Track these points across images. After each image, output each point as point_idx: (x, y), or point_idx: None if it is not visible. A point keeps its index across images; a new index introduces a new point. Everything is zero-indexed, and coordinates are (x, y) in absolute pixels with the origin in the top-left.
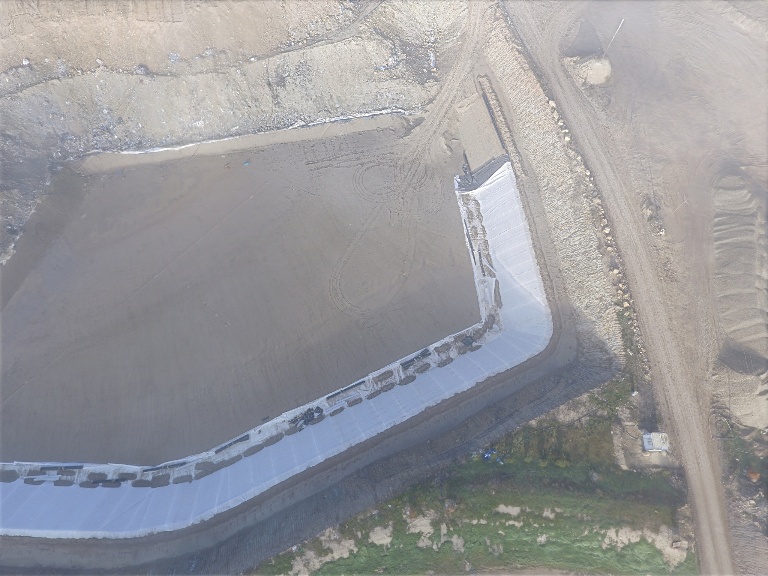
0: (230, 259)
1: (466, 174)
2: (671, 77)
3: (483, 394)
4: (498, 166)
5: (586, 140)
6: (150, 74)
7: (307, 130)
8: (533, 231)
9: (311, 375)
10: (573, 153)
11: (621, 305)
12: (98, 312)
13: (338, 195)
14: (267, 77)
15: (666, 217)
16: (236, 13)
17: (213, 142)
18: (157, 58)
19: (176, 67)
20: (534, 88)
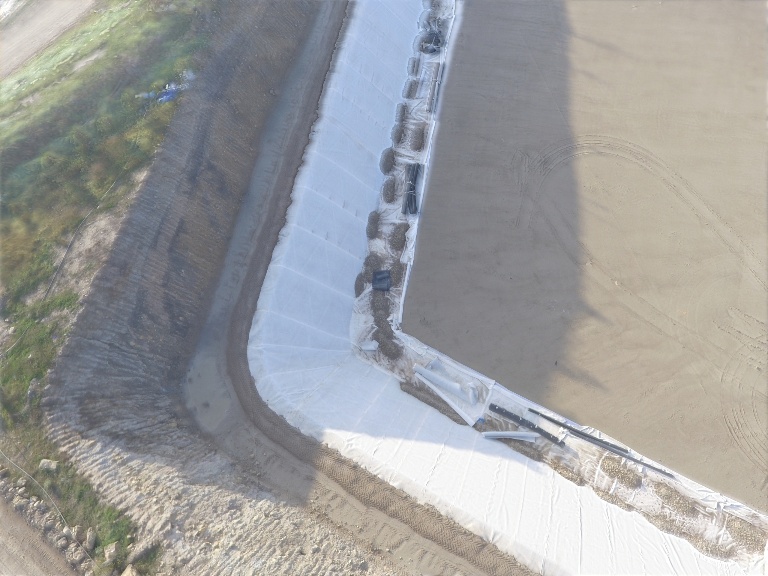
0: (766, 44)
1: None
2: None
3: (268, 198)
4: None
5: None
6: None
7: None
8: None
9: (486, 61)
10: None
11: (141, 561)
12: None
13: None
14: None
15: None
16: None
17: None
18: None
19: None
20: None
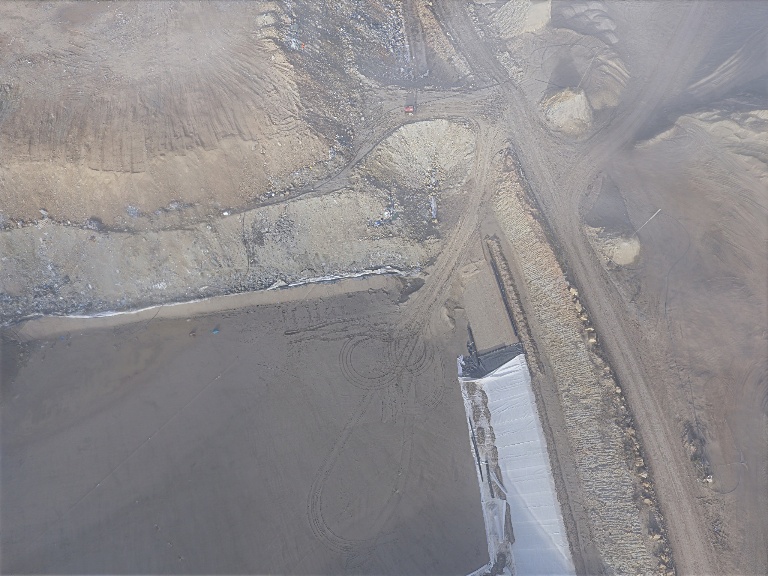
0: (190, 463)
1: (471, 355)
2: (707, 256)
3: None
4: (509, 356)
5: (614, 341)
6: (103, 229)
7: (288, 291)
8: (552, 452)
9: None
10: (600, 360)
11: None
12: (23, 536)
13: (322, 378)
14: (242, 233)
15: (712, 455)
16: (207, 162)
17: (177, 305)
18: (112, 211)
19: (135, 222)
20: (552, 266)
